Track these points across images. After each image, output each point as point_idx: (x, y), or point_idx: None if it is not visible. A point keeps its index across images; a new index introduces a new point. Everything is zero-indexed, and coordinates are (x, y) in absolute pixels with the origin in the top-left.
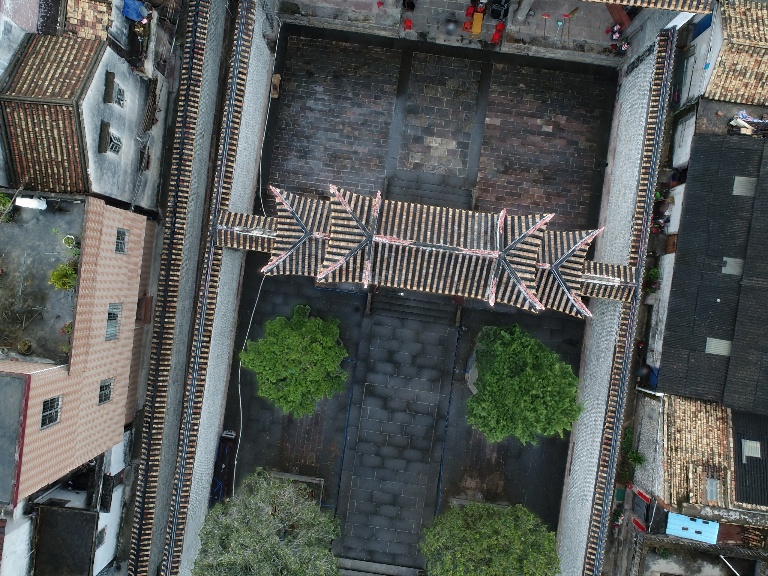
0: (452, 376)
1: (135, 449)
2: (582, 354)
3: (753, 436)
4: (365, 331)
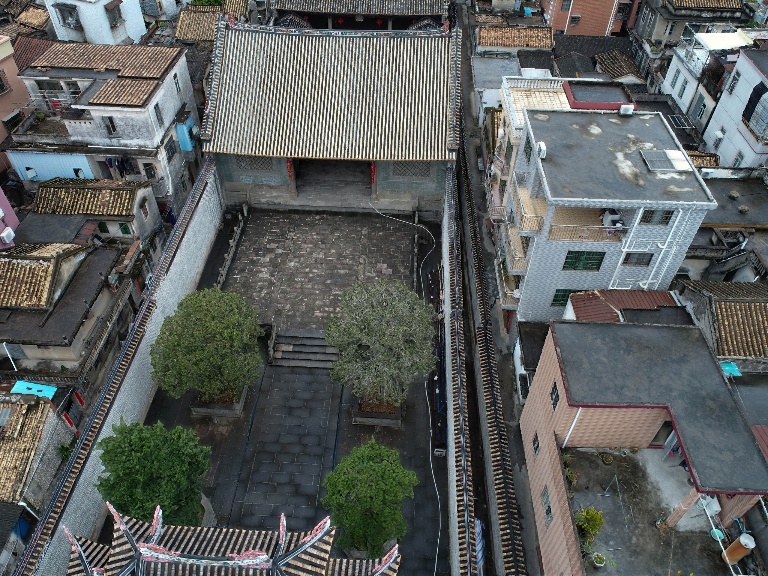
0: (230, 521)
1: (519, 433)
2: None
3: None
4: None
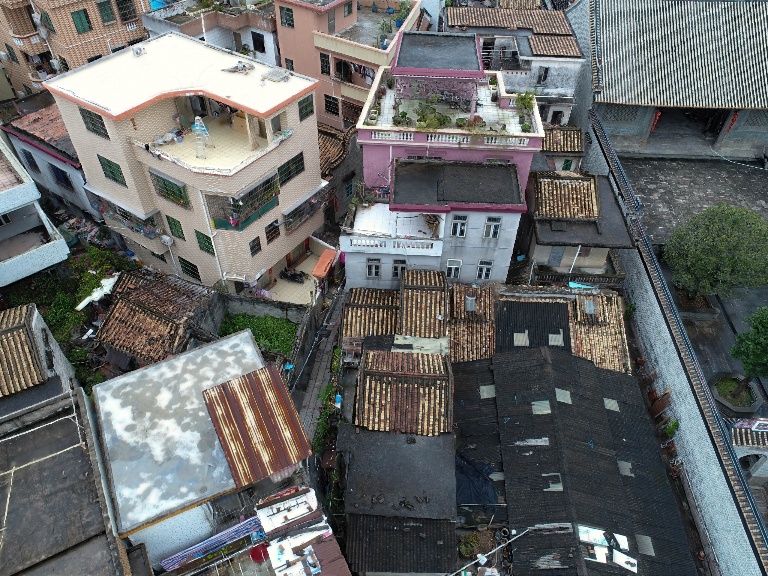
0: None
1: None
2: None
3: None
4: None
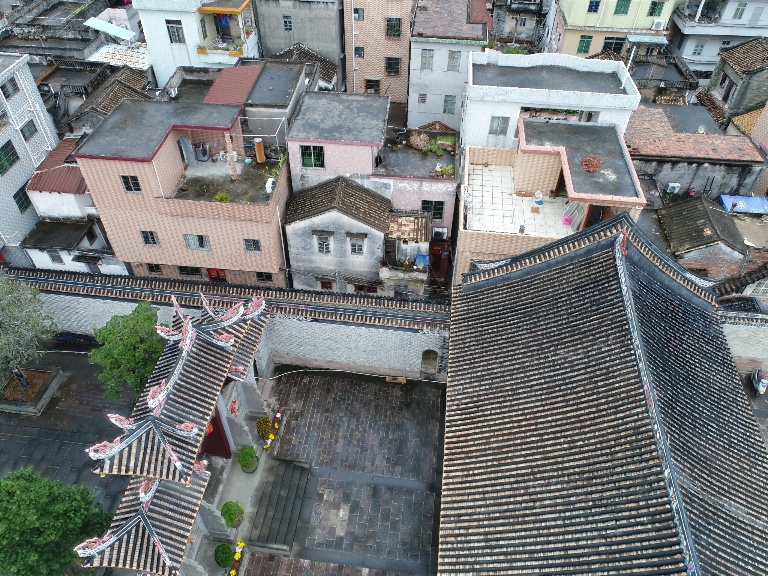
0: None
1: None
2: None
3: None
4: None
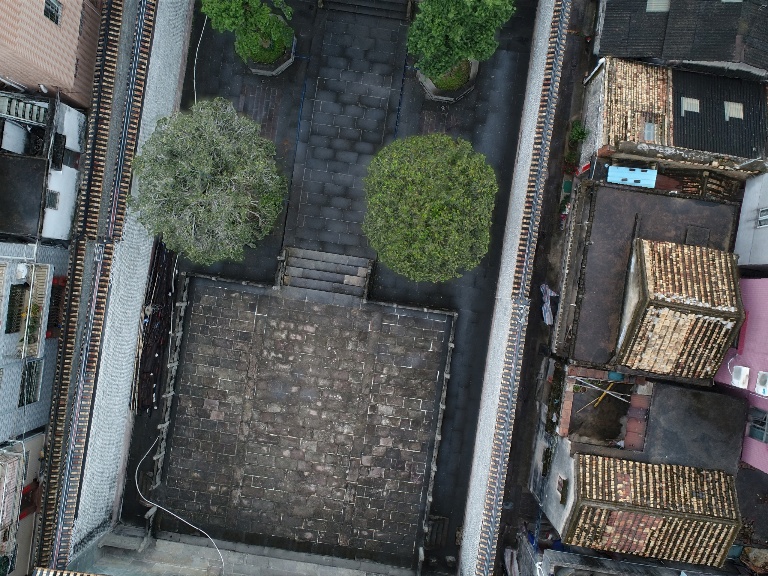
0: (403, 71)
1: None
2: (531, 49)
3: (693, 95)
4: (318, 26)
